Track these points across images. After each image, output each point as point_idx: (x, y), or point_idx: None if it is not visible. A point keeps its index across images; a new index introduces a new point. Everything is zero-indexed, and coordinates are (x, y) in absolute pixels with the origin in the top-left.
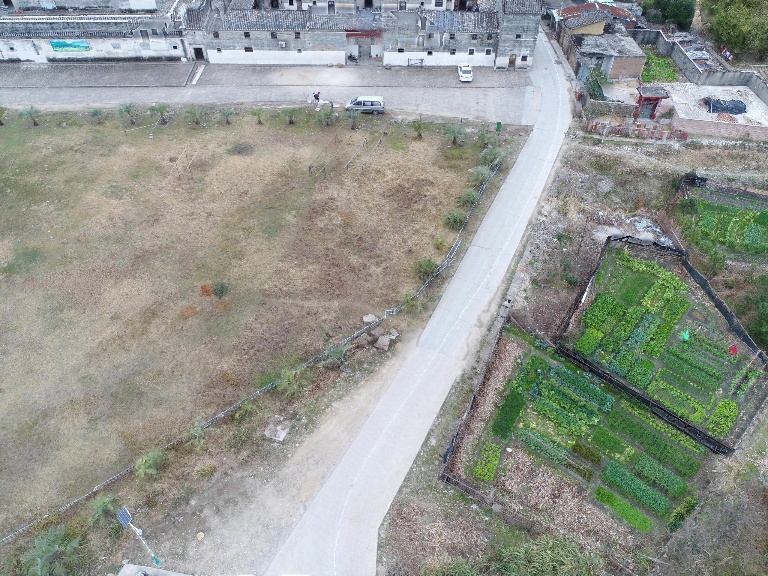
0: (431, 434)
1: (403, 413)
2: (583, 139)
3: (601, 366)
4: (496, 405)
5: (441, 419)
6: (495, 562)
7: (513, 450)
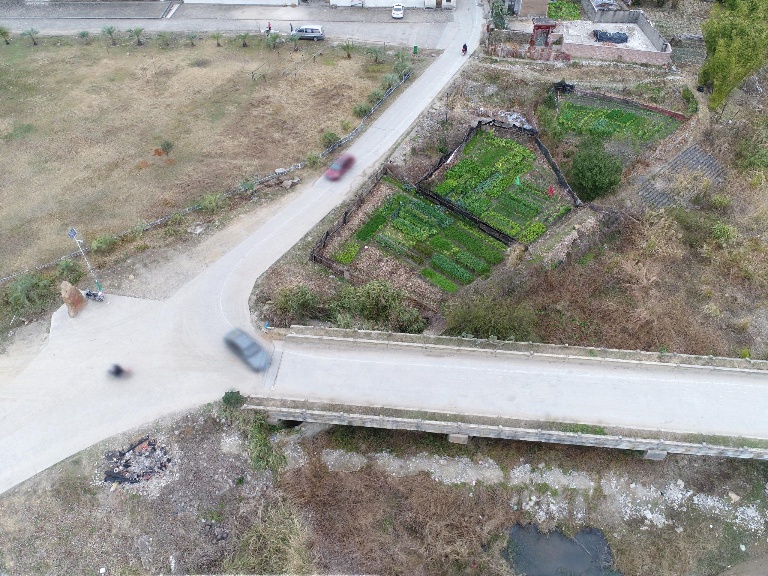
0: (309, 234)
1: (291, 222)
2: (483, 59)
3: None
4: (364, 222)
5: (319, 227)
6: (337, 301)
7: (369, 248)
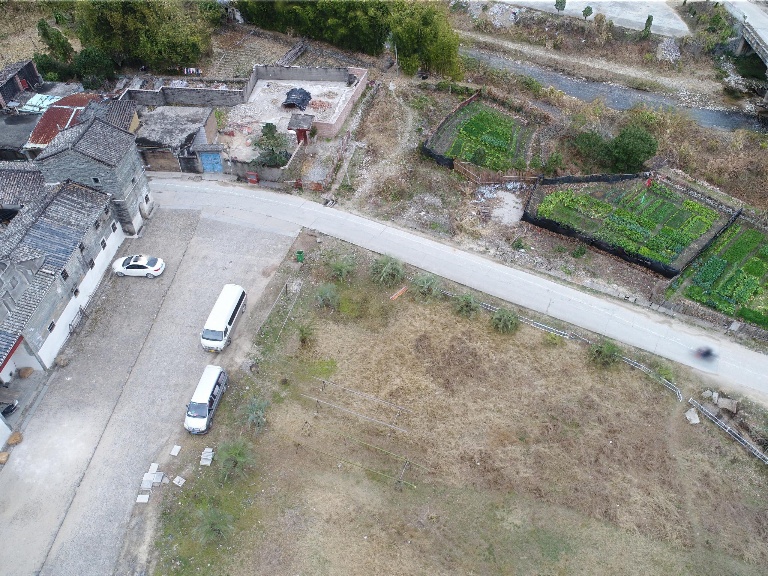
0: None
1: None
2: (341, 196)
3: None
4: None
5: None
6: None
7: None
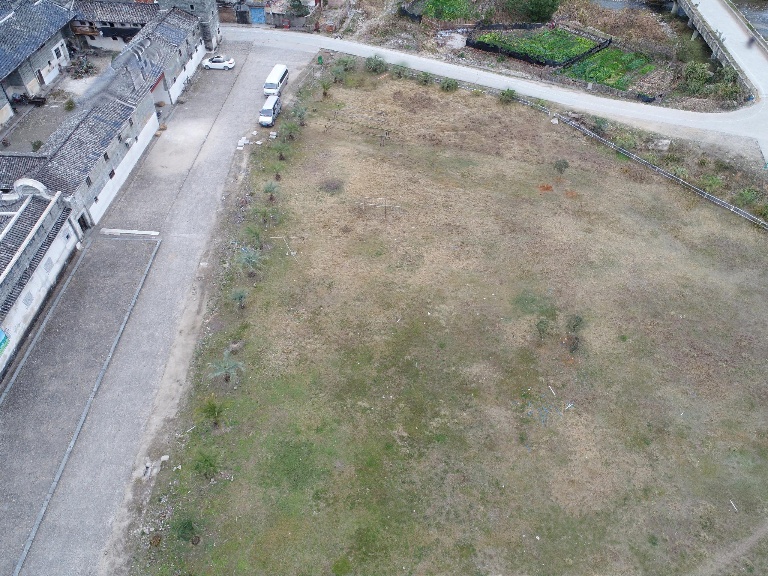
0: None
1: (629, 109)
2: (345, 34)
3: None
4: None
5: None
6: None
7: None
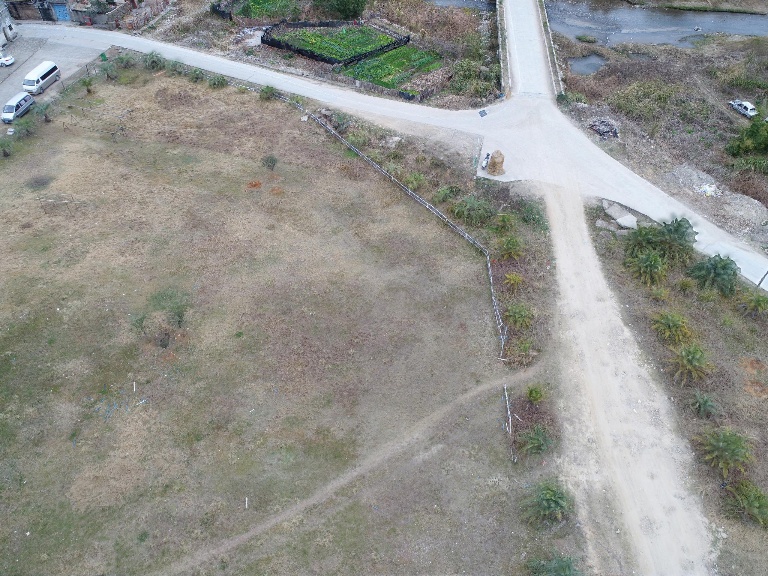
0: None
1: (383, 106)
2: (145, 31)
3: None
4: None
5: None
6: None
7: None
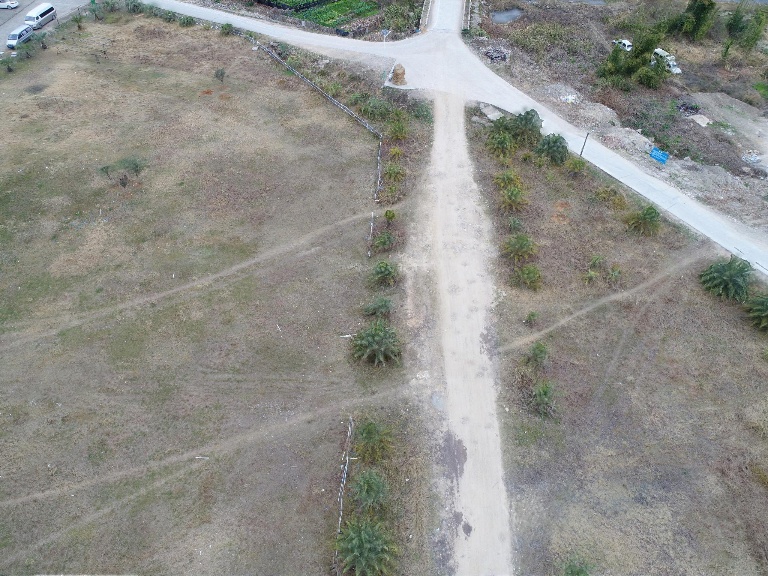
0: None
1: None
2: None
3: (305, 8)
4: None
5: None
6: None
7: None
